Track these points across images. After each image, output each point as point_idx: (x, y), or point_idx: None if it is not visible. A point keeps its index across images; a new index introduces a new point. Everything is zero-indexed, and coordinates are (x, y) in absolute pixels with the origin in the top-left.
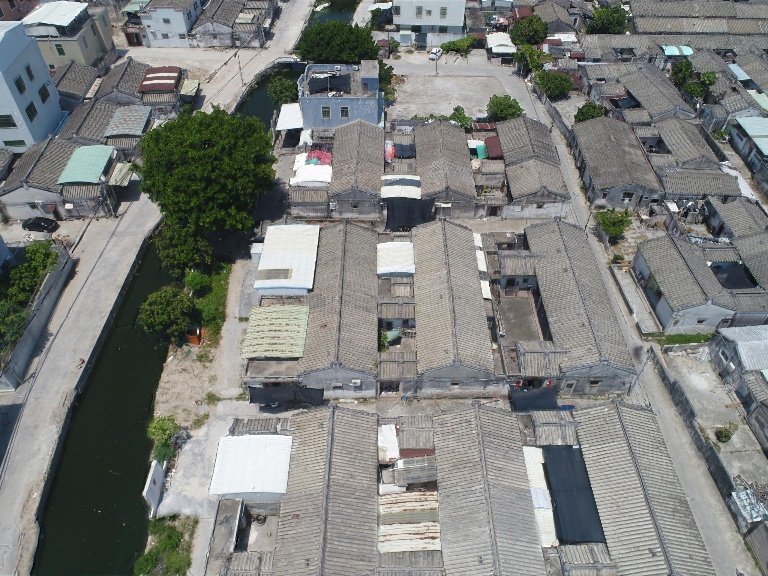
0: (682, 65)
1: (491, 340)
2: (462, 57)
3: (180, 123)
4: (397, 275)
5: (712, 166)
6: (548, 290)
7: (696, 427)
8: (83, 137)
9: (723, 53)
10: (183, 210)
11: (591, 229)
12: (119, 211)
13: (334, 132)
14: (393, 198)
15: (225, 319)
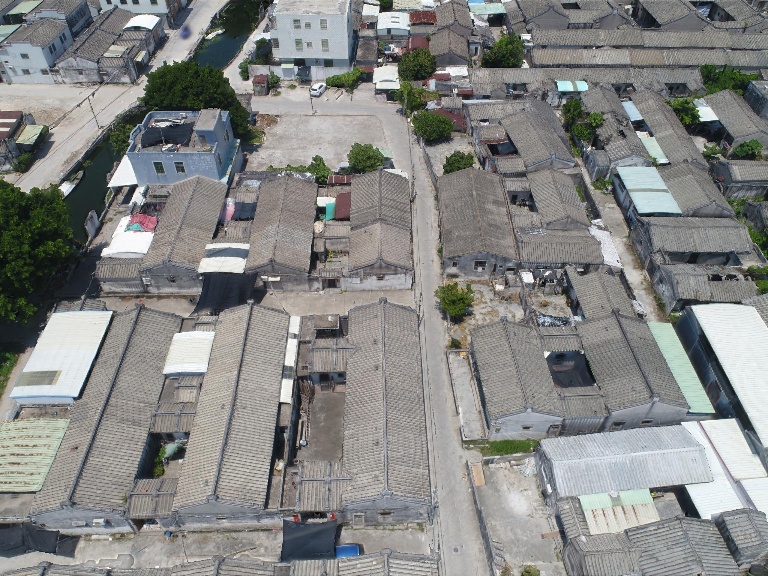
0: (571, 104)
1: None
2: (347, 93)
3: None
4: (188, 374)
5: (580, 227)
6: (353, 393)
7: (494, 572)
8: None
9: (624, 87)
10: None
11: (438, 303)
12: None
13: (172, 188)
14: (211, 273)
15: None
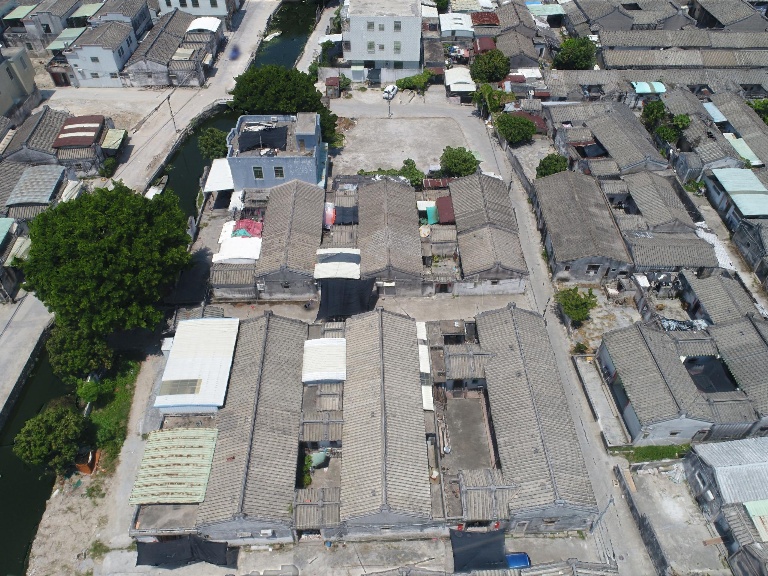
0: (653, 106)
1: (434, 459)
2: (419, 95)
3: (73, 205)
4: (325, 381)
5: (686, 229)
6: (498, 400)
7: None
8: None
9: (698, 88)
10: (72, 312)
11: (552, 307)
12: (19, 294)
13: (269, 193)
14: (328, 279)
15: (126, 437)
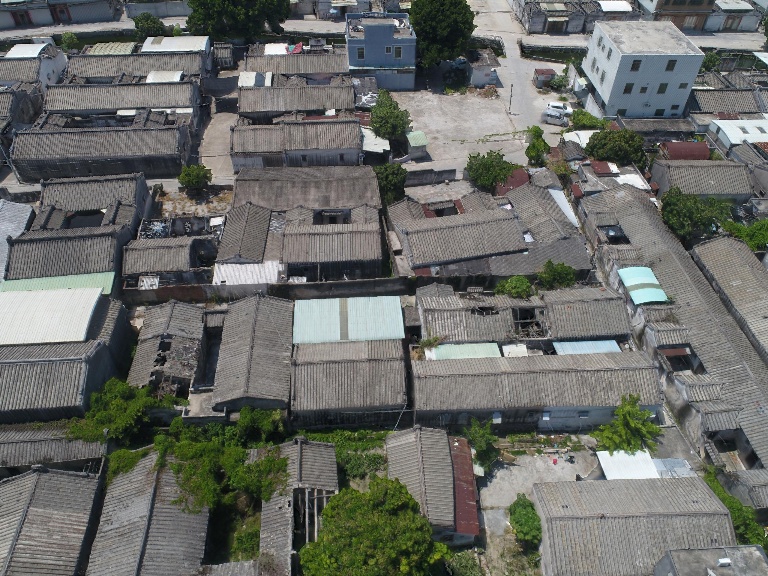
0: (556, 265)
1: None
2: None
3: None
4: None
5: None
6: None
7: None
8: None
9: None
10: None
11: None
12: None
13: None
14: None
15: None
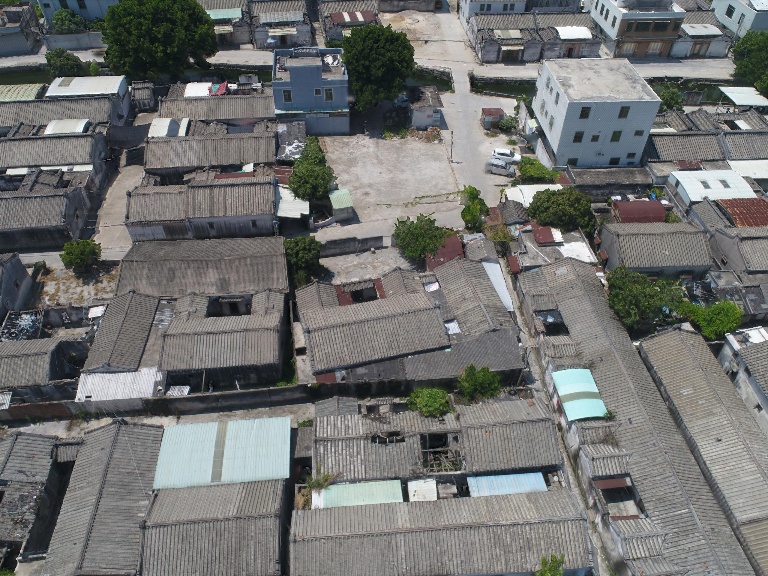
0: (478, 371)
1: None
2: None
3: None
4: None
5: None
6: None
7: None
8: (252, 5)
9: None
10: None
11: None
12: None
13: None
14: None
15: None
